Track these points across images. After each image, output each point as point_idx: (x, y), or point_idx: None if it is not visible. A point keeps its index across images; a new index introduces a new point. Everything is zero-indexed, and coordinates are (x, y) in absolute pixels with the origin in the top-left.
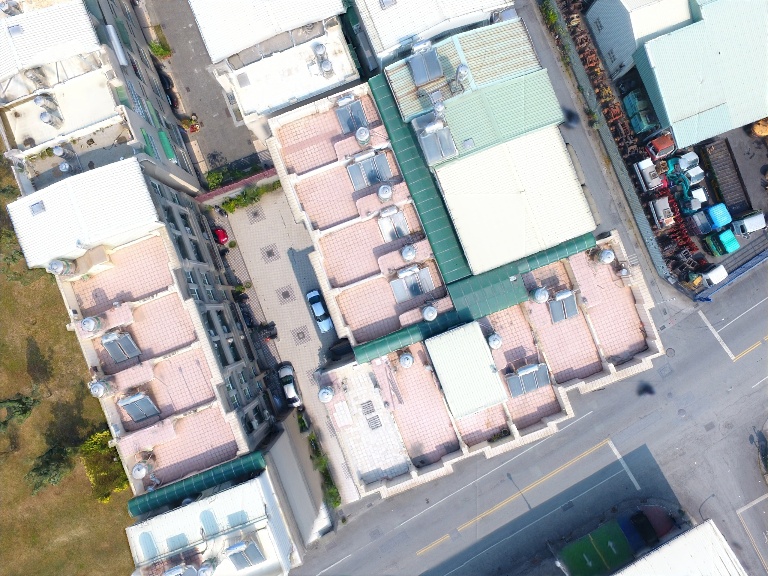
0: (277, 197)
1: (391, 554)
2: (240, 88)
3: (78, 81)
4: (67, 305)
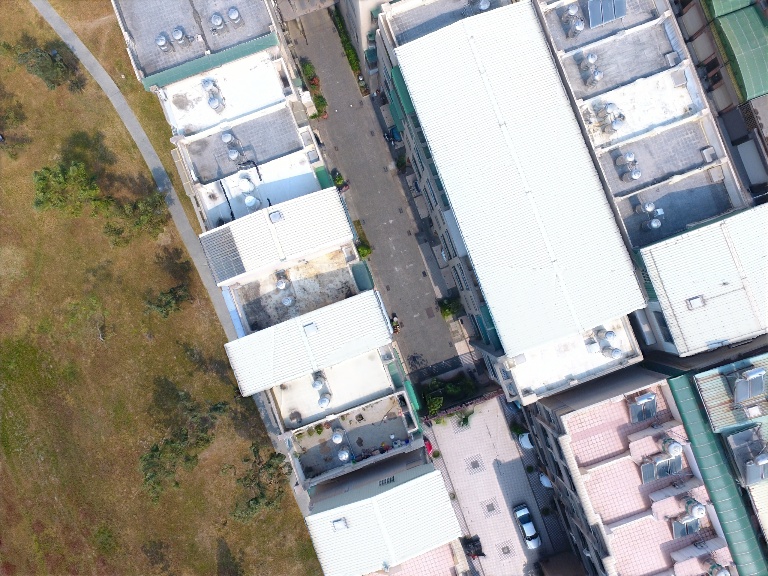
0: (482, 406)
1: None
2: None
3: None
4: None
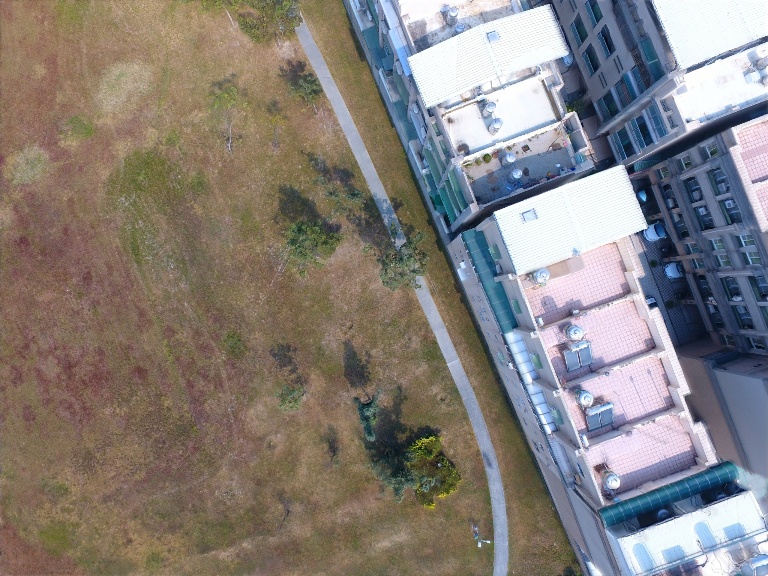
0: None
1: None
2: (677, 95)
3: (516, 87)
4: (531, 313)
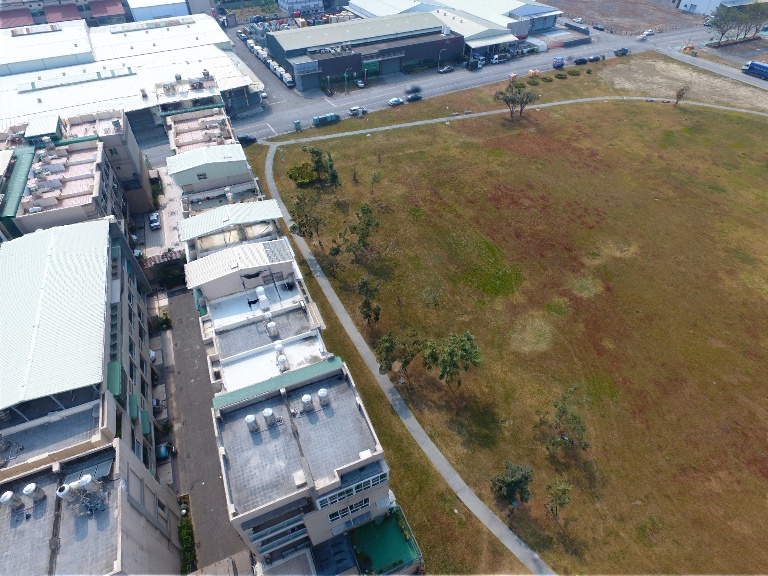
0: None
1: None
2: None
3: None
4: None
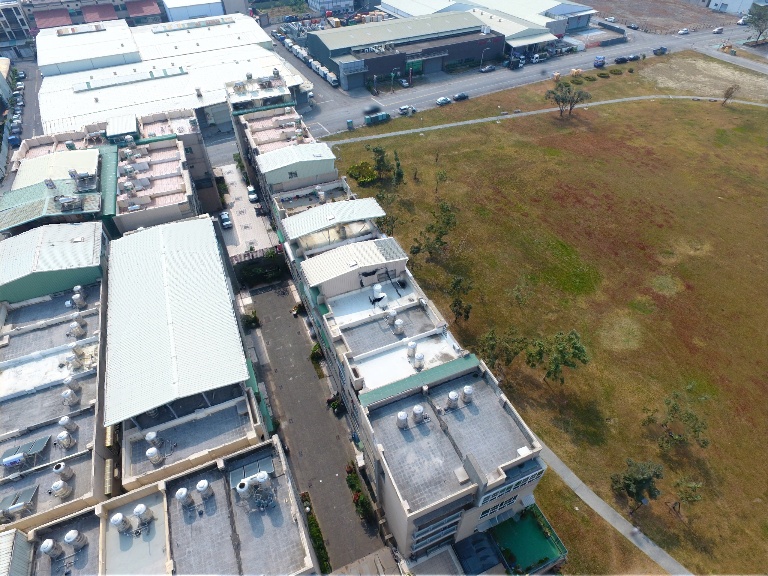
0: None
1: (218, 152)
2: None
3: None
4: None
